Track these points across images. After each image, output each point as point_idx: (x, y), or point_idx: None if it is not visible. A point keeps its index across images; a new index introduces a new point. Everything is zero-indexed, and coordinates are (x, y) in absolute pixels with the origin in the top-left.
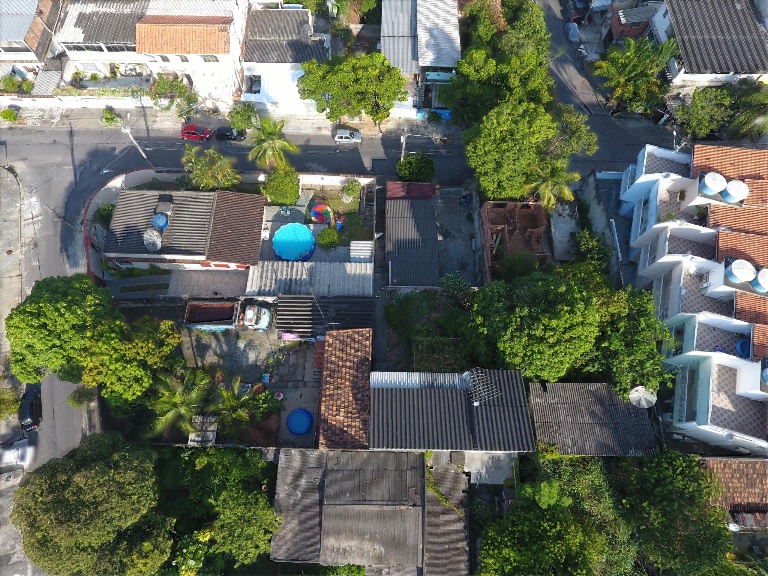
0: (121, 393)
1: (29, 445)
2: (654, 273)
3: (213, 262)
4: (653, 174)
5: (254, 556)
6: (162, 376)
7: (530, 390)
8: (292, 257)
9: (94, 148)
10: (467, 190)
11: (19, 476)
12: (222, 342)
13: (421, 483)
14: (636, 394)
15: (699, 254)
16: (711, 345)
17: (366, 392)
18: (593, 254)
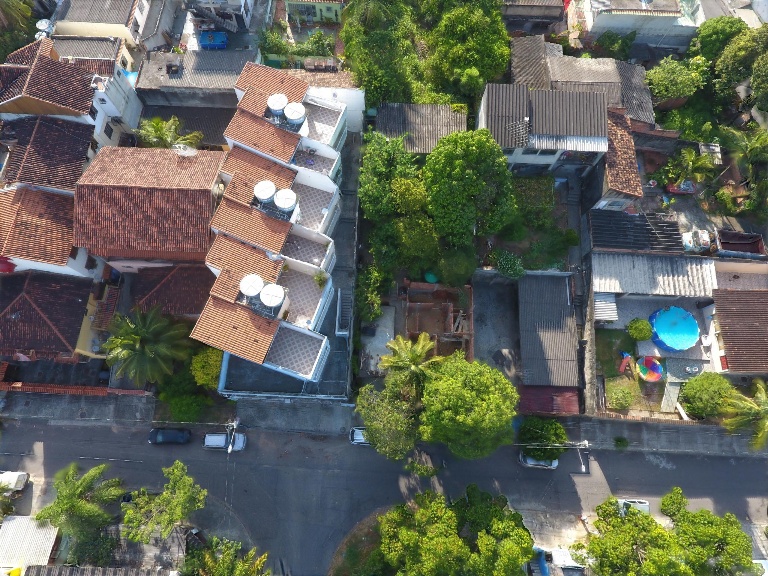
0: None
1: None
2: None
3: None
4: (318, 333)
5: None
6: None
7: None
8: (673, 310)
9: None
10: None
11: None
12: None
13: None
14: None
15: (290, 252)
16: (315, 167)
17: None
18: (373, 287)
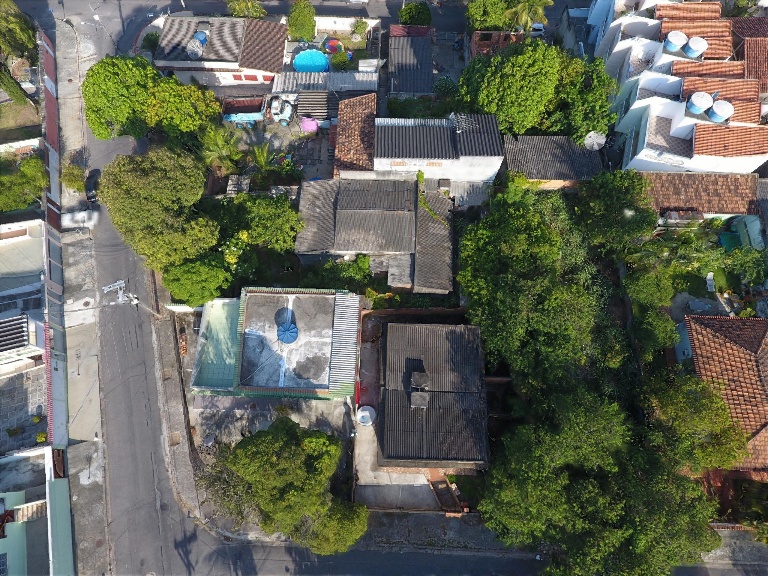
0: (178, 124)
1: (93, 214)
2: (612, 69)
3: (244, 70)
4: None
5: (282, 250)
6: (208, 125)
7: (504, 140)
8: None
9: (138, 6)
10: (459, 34)
11: (86, 233)
12: (252, 135)
13: (415, 198)
14: (590, 140)
15: None
16: None
17: (371, 135)
18: None
